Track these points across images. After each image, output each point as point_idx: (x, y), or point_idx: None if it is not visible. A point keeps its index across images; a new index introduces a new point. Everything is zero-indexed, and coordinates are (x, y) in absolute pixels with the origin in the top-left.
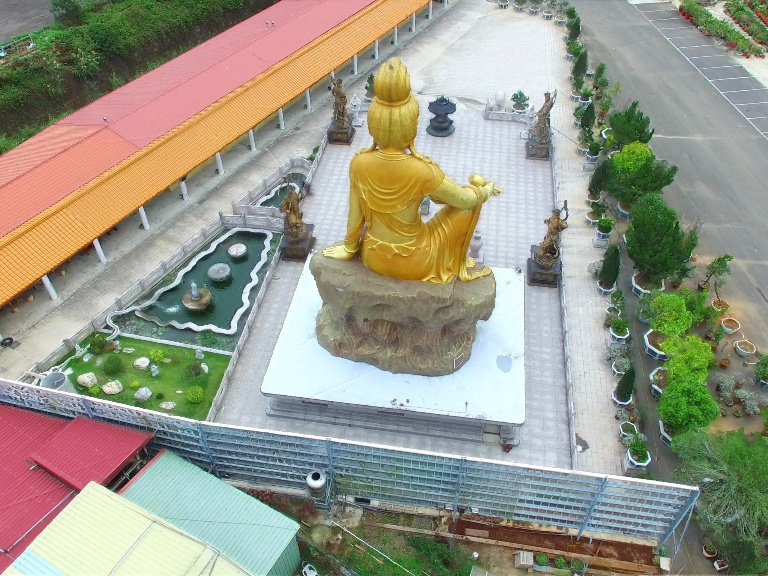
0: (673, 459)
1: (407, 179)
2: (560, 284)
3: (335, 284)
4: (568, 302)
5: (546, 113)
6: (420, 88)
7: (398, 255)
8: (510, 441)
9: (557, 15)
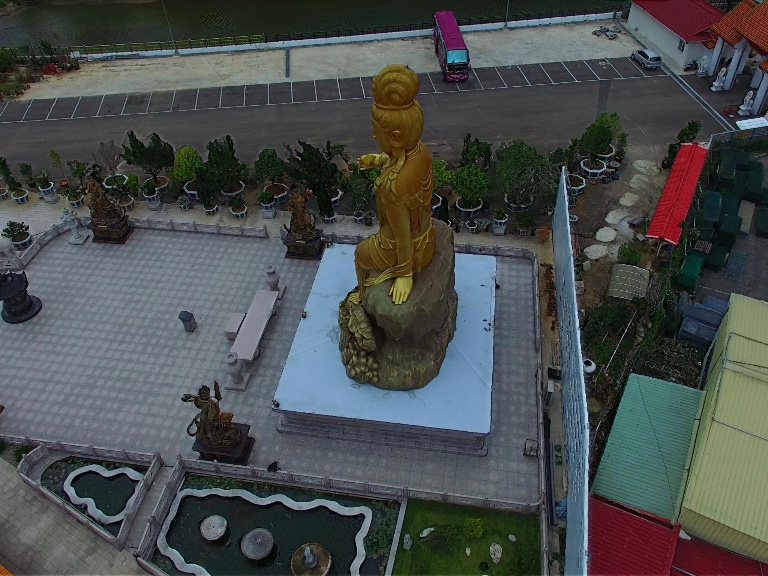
0: (486, 215)
1: None
2: (323, 240)
3: None
4: None
5: None
6: None
7: None
8: None
9: None
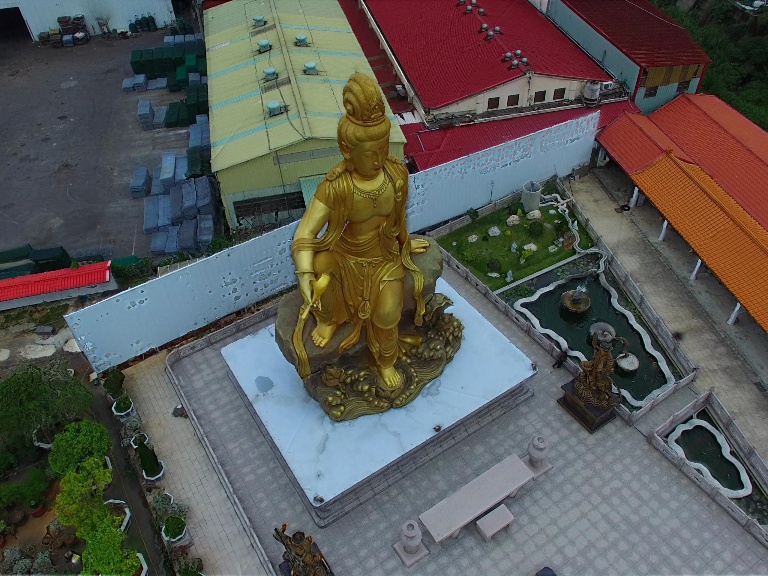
0: None
1: None
2: None
3: None
4: (260, 570)
5: None
6: None
7: None
8: None
9: None
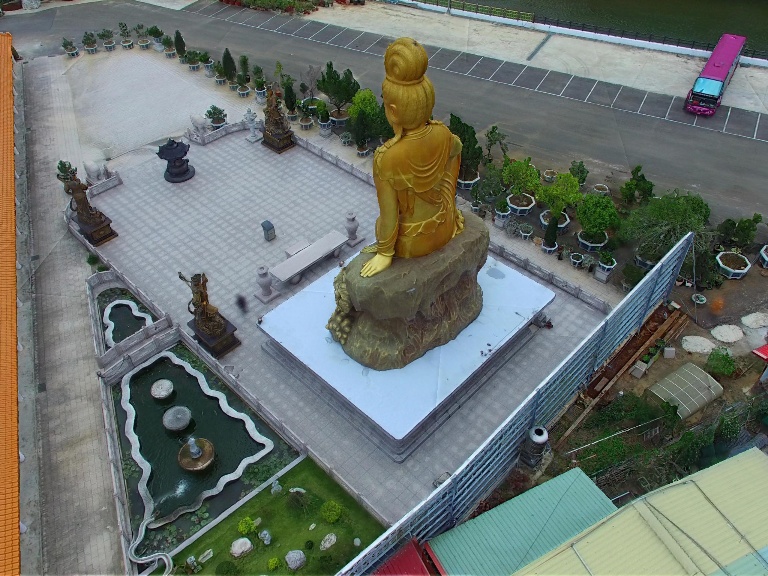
0: None
1: (441, 145)
2: None
3: (405, 289)
4: None
5: (277, 105)
6: (102, 155)
7: (440, 224)
8: (546, 319)
9: (139, 40)
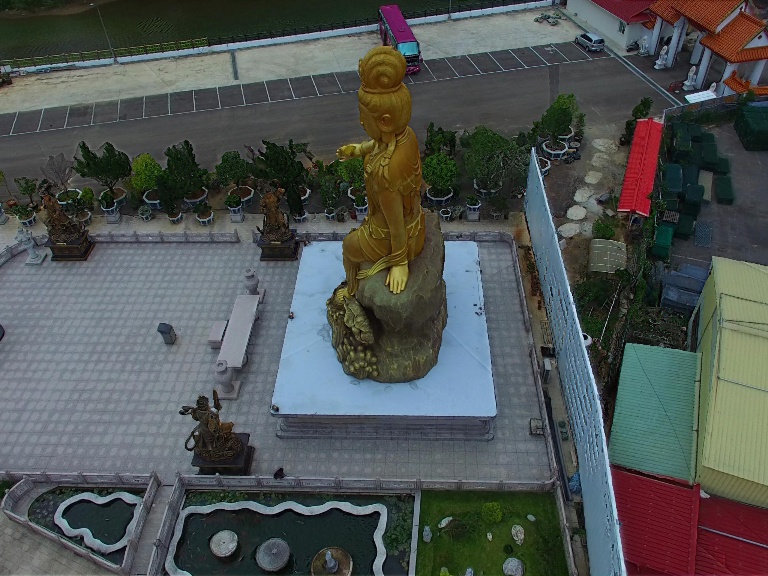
0: (458, 203)
1: None
2: (297, 240)
3: None
4: None
5: None
6: None
7: None
8: None
9: None
